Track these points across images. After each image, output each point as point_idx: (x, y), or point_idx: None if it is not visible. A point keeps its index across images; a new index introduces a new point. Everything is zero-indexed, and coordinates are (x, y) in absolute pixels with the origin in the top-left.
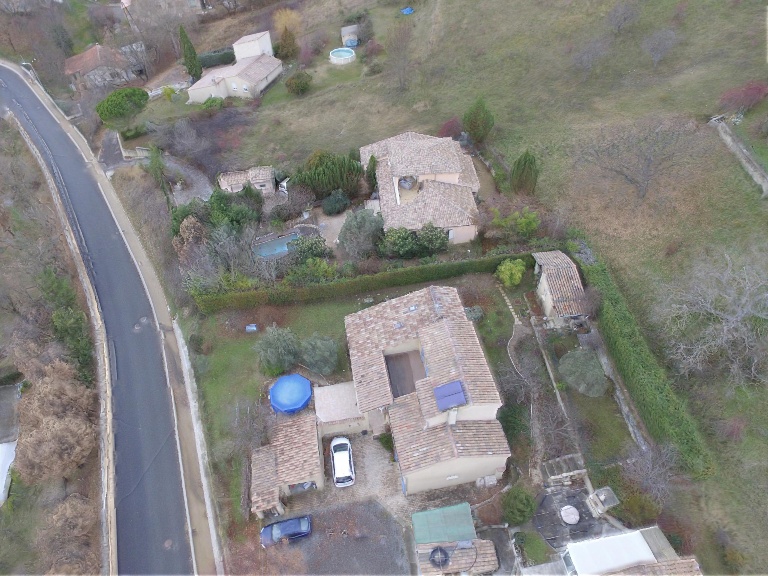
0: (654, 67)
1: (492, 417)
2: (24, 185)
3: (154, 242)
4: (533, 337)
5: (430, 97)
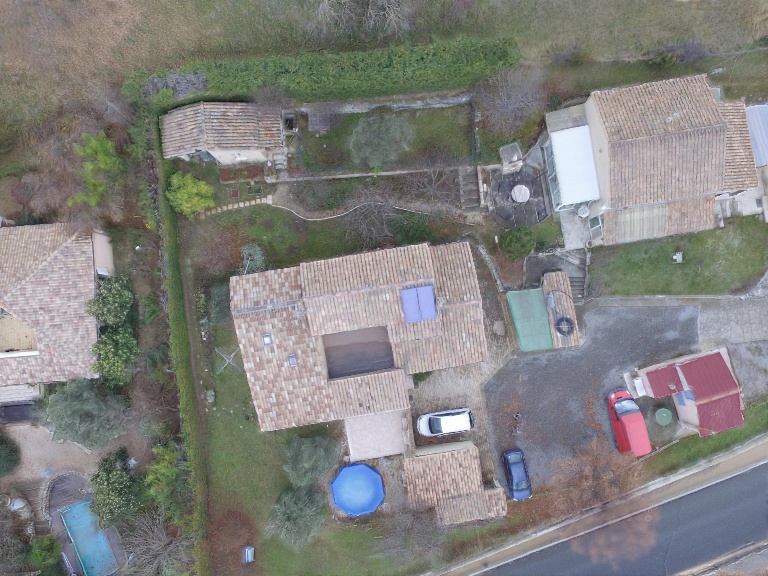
0: None
1: None
2: None
3: None
4: (294, 185)
5: None
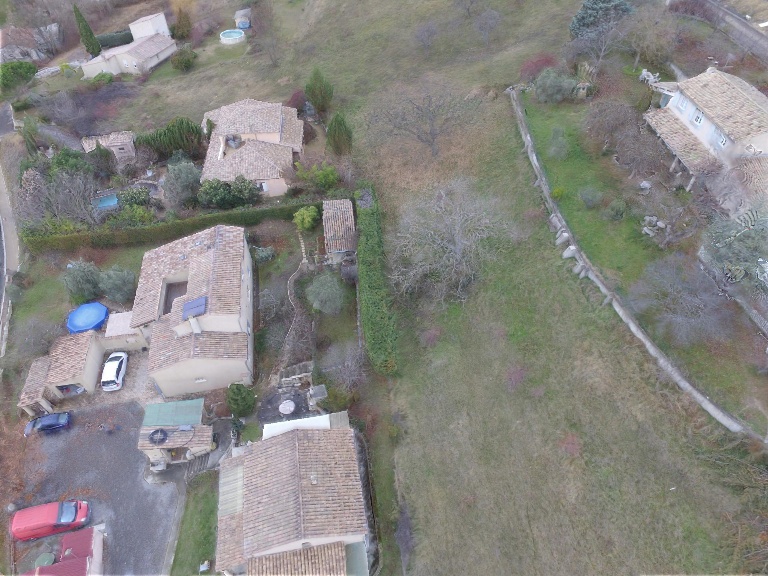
0: (487, 45)
1: (238, 329)
2: None
3: (20, 200)
4: (313, 272)
5: (295, 73)
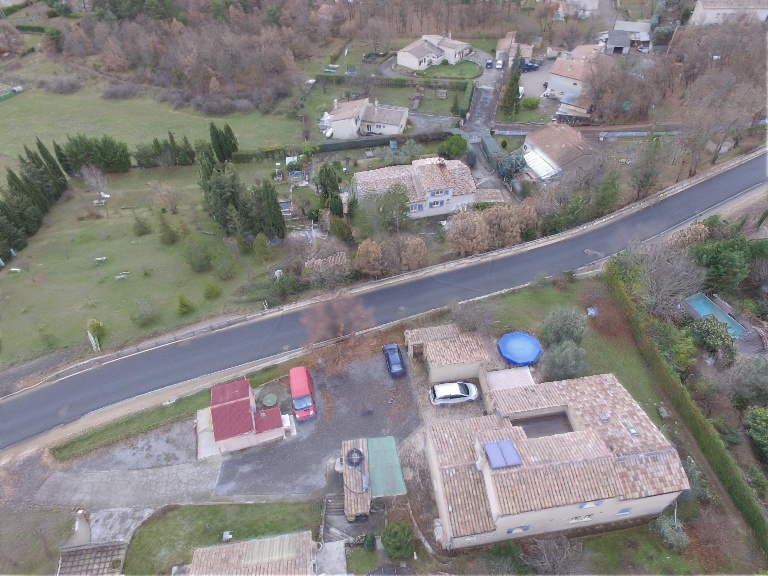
0: None
1: None
2: (706, 133)
3: None
4: None
5: None
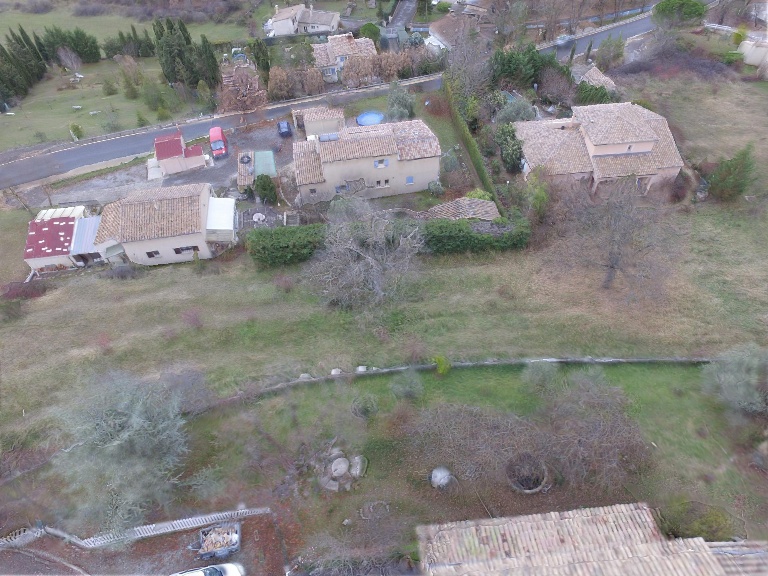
0: None
1: None
2: (553, 5)
3: None
4: None
5: None
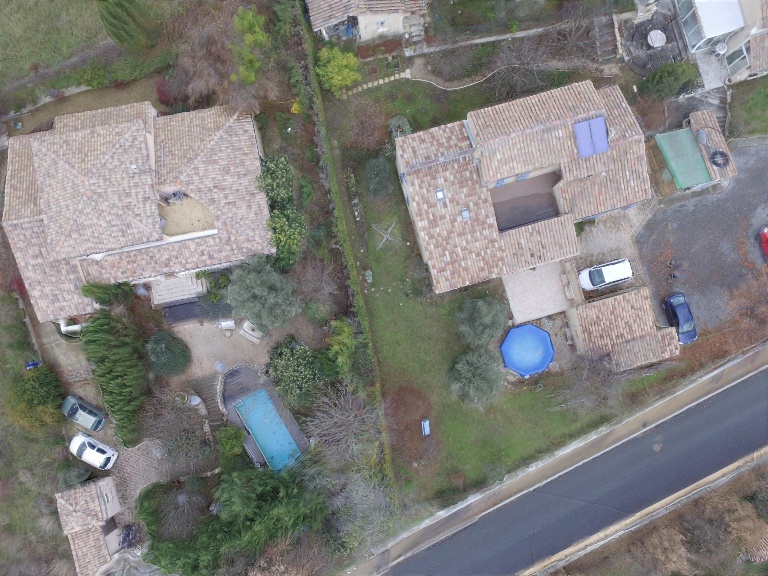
0: None
1: None
2: None
3: None
4: (431, 56)
5: None
